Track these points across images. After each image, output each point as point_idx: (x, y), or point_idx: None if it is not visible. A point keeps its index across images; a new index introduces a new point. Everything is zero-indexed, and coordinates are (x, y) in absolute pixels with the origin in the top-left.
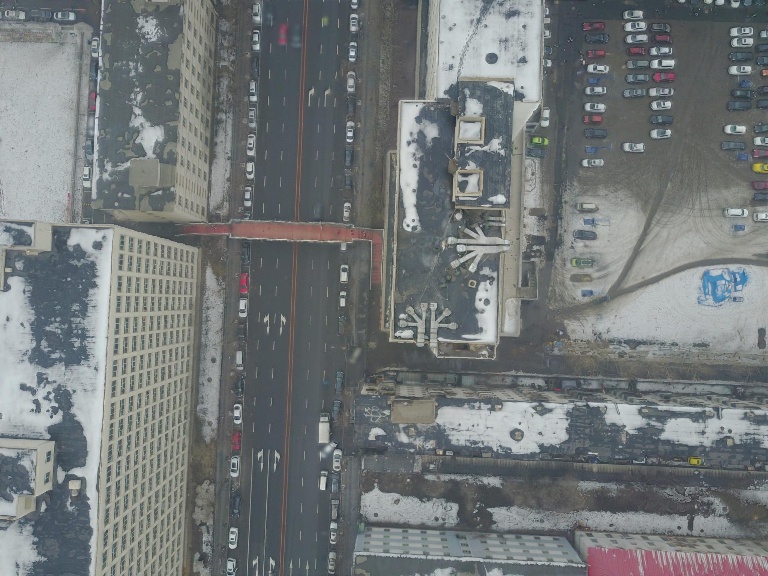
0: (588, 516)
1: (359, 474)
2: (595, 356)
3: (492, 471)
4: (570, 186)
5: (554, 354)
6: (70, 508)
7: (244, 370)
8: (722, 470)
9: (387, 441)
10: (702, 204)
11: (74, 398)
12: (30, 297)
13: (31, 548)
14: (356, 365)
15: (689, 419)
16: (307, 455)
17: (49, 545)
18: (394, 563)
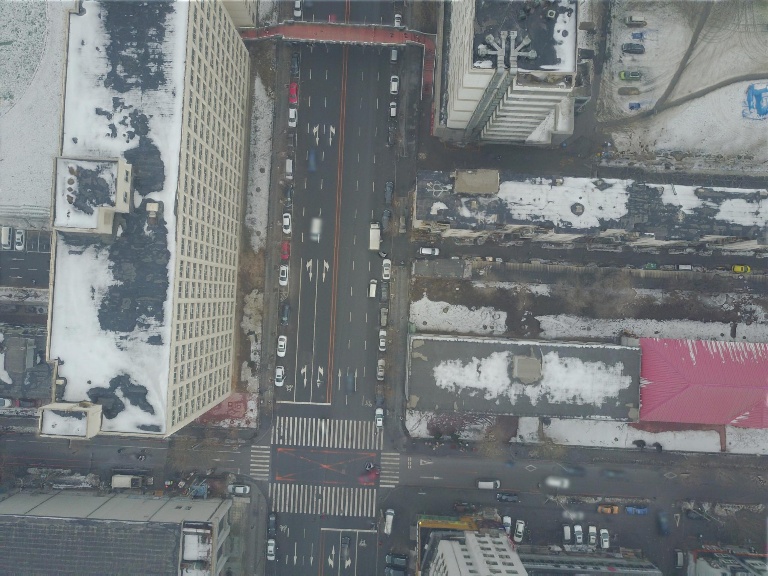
0: (634, 324)
1: (408, 283)
2: (642, 168)
3: (541, 276)
4: (619, 1)
5: (602, 166)
6: (147, 232)
7: (293, 181)
8: (765, 275)
9: (449, 215)
10: (748, 20)
11: (151, 123)
12: (106, 22)
13: (107, 272)
14: (406, 176)
15: (743, 199)
16: (356, 265)
17: (125, 269)
18: (451, 347)
